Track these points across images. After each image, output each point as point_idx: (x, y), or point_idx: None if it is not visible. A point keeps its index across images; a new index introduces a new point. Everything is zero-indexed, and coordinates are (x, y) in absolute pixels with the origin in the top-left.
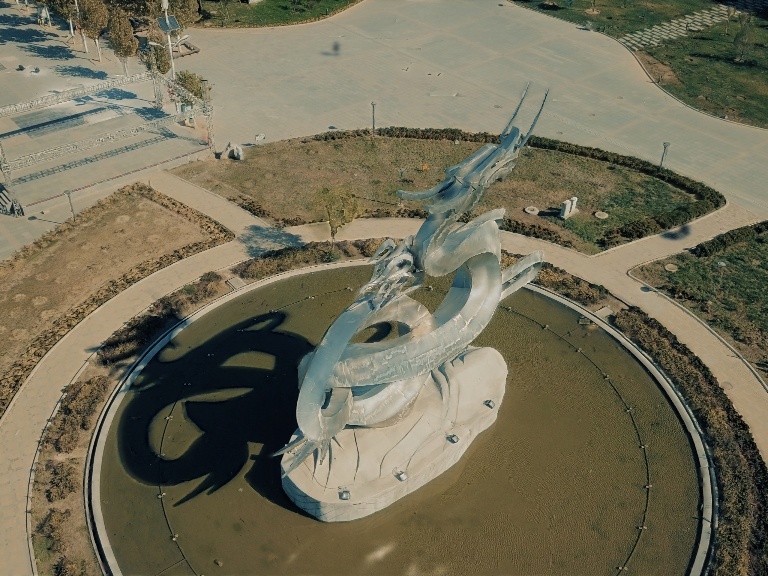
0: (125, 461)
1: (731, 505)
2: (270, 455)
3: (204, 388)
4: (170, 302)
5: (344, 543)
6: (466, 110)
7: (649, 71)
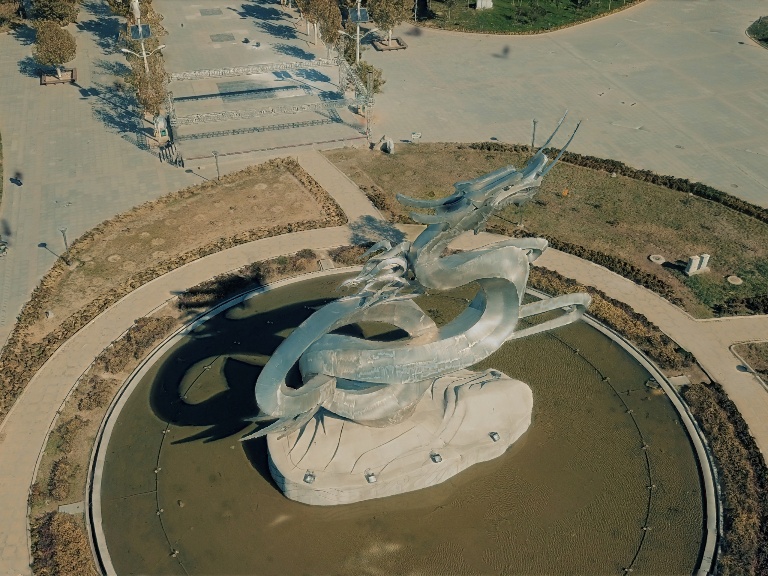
0: (153, 394)
1: None
2: None
3: (249, 350)
4: (260, 267)
5: (296, 523)
6: (642, 145)
7: None
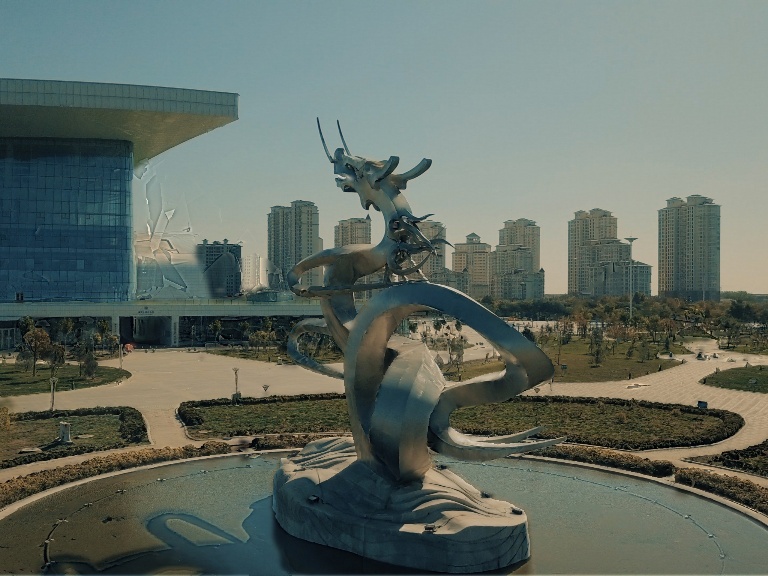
0: None
1: None
2: None
3: None
4: None
5: (561, 554)
6: None
7: None
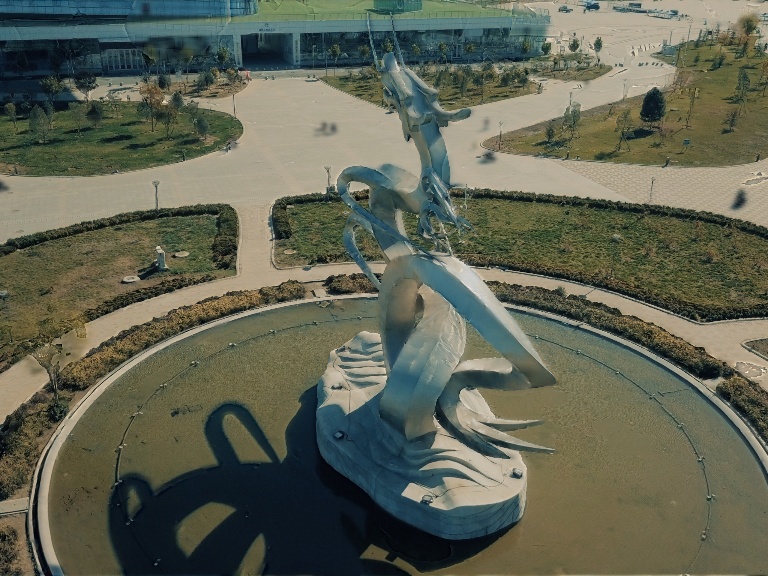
0: None
1: (574, 309)
2: None
3: None
4: None
5: (553, 513)
6: None
7: None
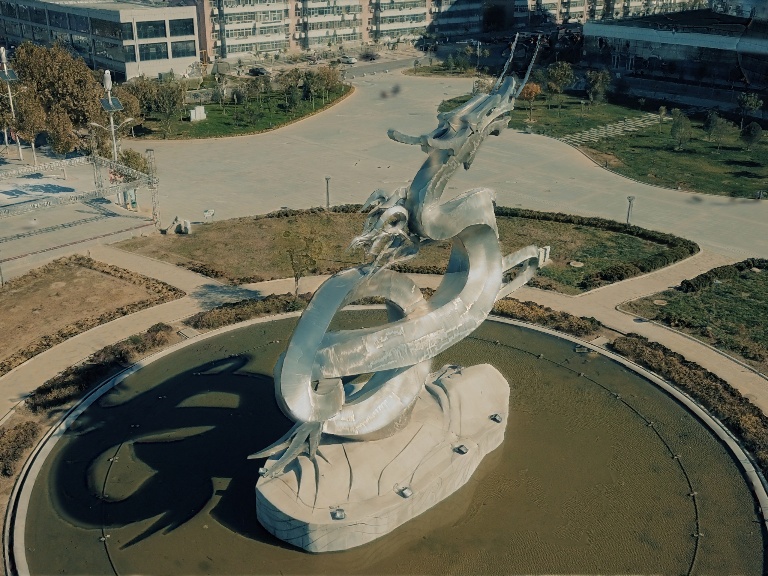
0: (58, 505)
1: None
2: (239, 491)
3: (155, 429)
4: (113, 352)
5: (341, 575)
6: None
7: (595, 159)
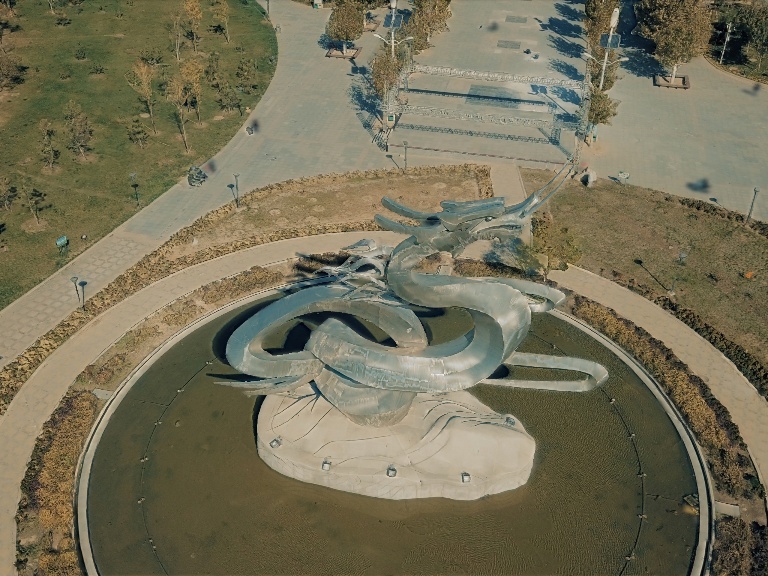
0: (223, 330)
1: None
2: None
3: None
4: None
5: (250, 478)
6: None
7: None
